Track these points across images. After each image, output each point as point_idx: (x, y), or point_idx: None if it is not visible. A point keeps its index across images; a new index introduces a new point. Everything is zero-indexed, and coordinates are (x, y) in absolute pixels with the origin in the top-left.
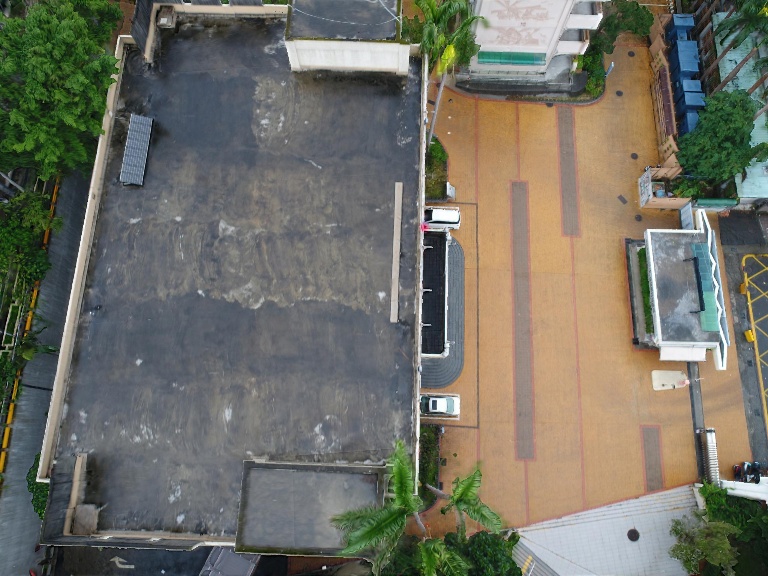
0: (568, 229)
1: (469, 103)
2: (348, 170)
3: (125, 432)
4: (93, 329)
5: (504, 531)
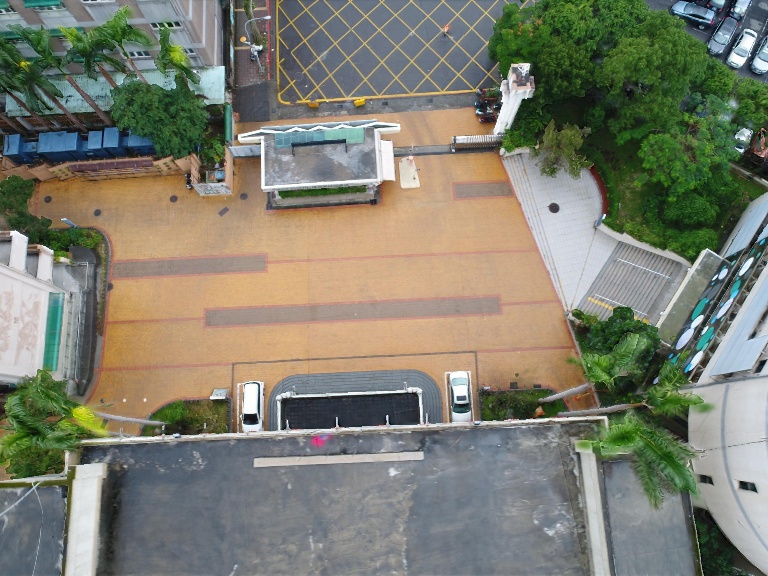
0: (259, 266)
1: (106, 378)
2: (239, 529)
3: None
4: None
5: (570, 324)
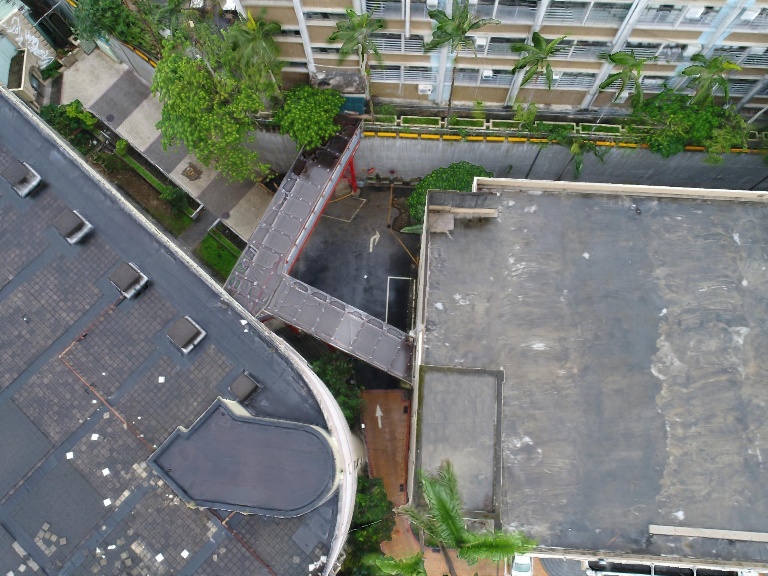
0: None
1: None
2: None
3: (518, 249)
4: (616, 209)
5: None
